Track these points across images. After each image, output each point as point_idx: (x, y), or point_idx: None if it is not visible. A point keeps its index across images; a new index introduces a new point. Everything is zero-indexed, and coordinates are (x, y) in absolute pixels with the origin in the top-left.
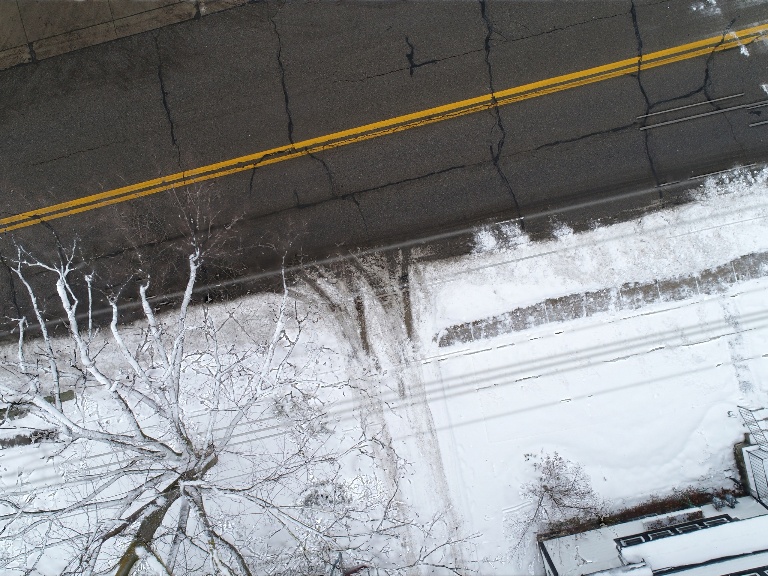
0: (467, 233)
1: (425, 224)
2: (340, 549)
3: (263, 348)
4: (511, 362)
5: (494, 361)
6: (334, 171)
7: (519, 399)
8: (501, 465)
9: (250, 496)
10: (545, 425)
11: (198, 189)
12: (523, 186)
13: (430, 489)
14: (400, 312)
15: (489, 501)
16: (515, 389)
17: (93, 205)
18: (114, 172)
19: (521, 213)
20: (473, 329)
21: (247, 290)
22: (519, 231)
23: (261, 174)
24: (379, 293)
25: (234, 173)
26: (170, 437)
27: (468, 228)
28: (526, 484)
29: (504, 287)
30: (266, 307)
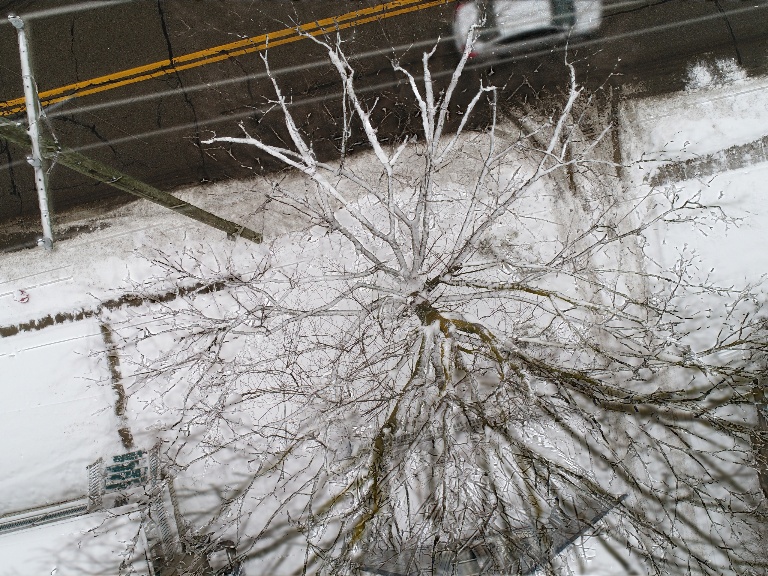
0: (681, 68)
1: (637, 59)
2: (628, 337)
3: (552, 121)
4: (730, 199)
5: (712, 198)
6: (543, 3)
7: (738, 237)
8: (718, 306)
9: (513, 295)
10: (765, 264)
11: (398, 22)
12: (741, 19)
13: (639, 334)
14: (609, 151)
15: (704, 344)
16: (734, 227)
17: (286, 39)
18: (309, 5)
19: (738, 47)
20: (686, 168)
21: (447, 129)
22: (736, 66)
23: (466, 6)
24: (586, 132)
25: (437, 5)
26: (407, 249)
27: (682, 63)
28: (755, 318)
29: (723, 121)
30: (468, 146)
